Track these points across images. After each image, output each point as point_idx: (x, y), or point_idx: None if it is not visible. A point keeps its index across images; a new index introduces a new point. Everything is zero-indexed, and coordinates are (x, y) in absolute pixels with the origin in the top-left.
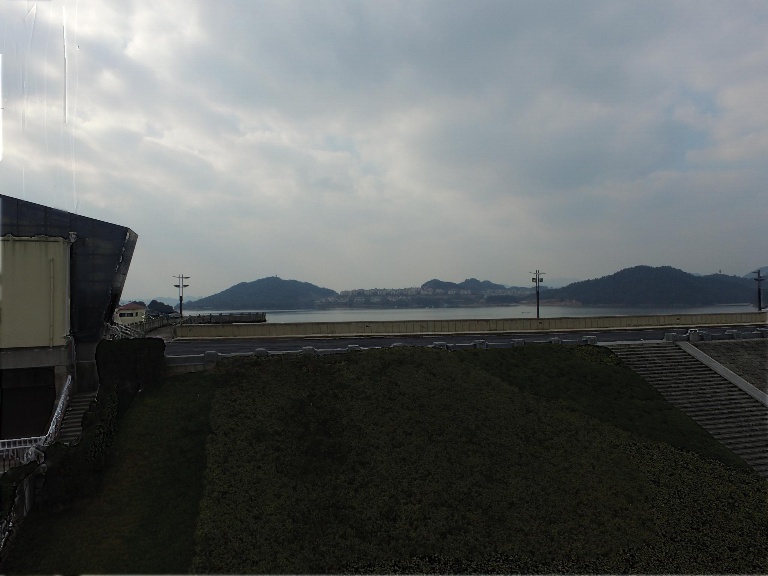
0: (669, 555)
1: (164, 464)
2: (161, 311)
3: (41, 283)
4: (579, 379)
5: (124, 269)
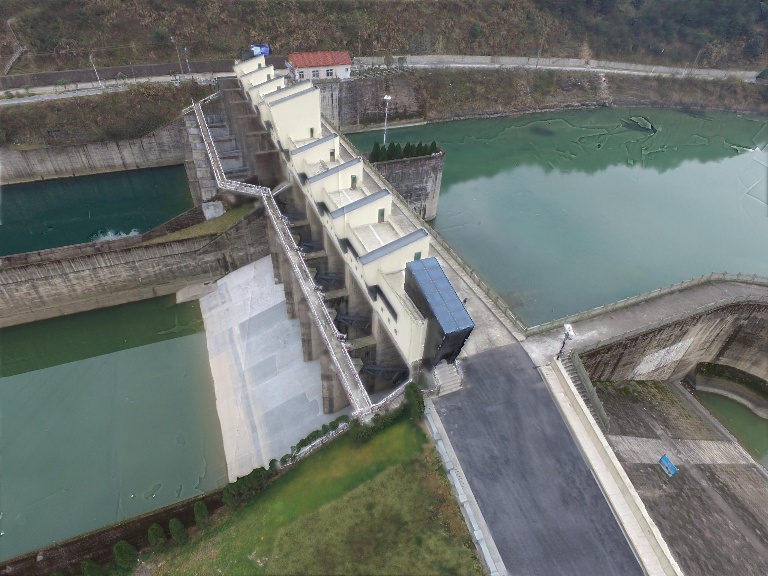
0: None
1: (364, 467)
2: None
3: (409, 335)
4: None
5: (464, 339)
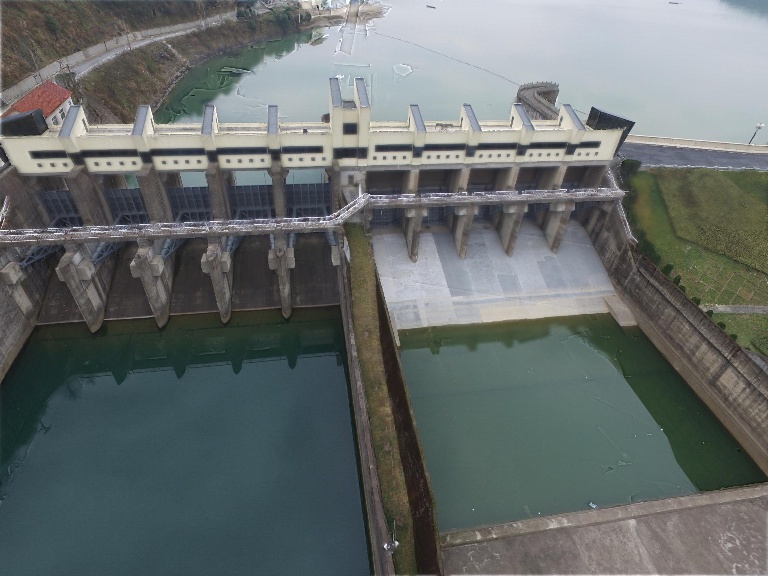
0: (763, 233)
1: (650, 199)
2: None
3: None
4: (760, 187)
5: None
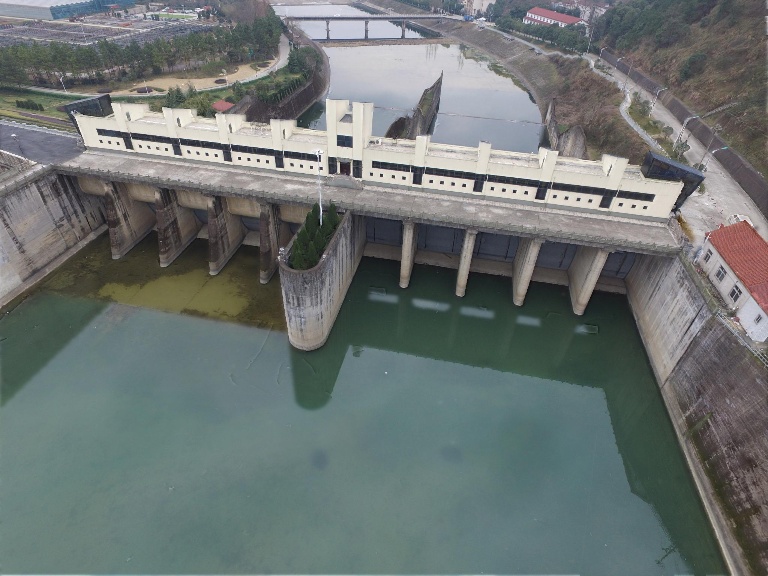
0: None
1: None
2: None
3: None
4: None
5: (72, 118)
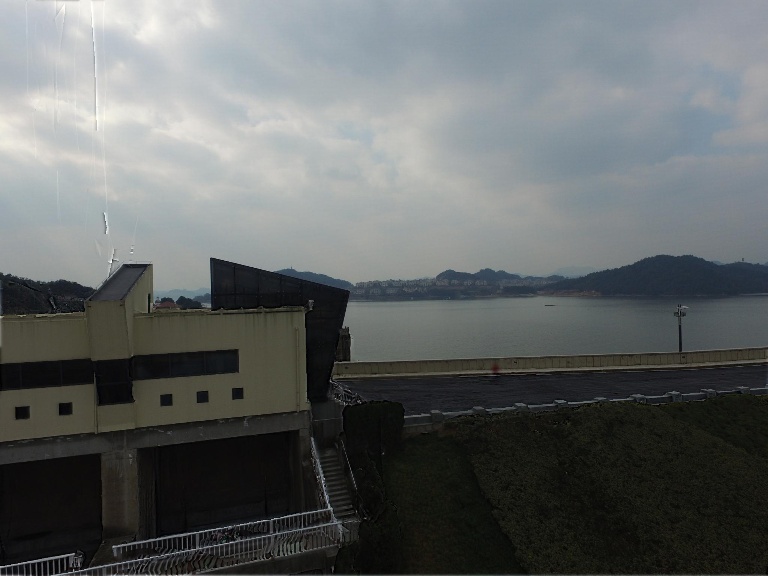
0: None
1: (458, 539)
2: (192, 307)
3: (288, 351)
4: None
5: None
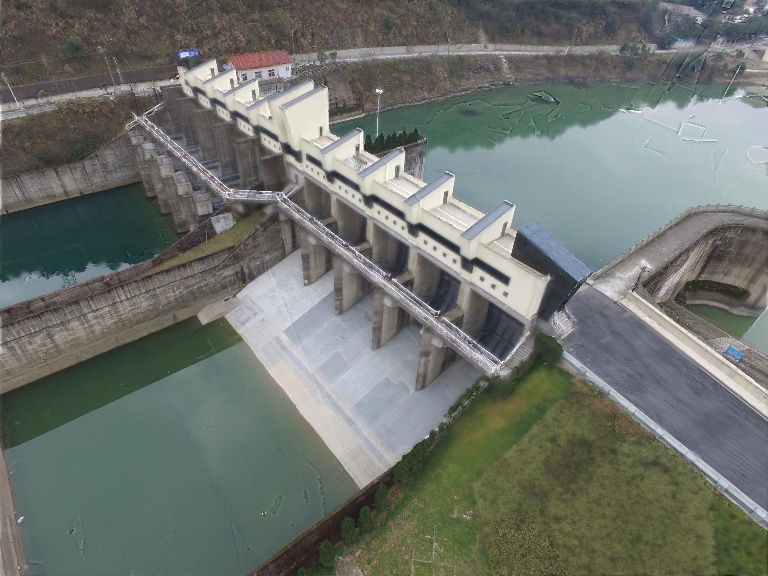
0: None
1: (523, 413)
2: None
3: (530, 292)
4: None
5: None
